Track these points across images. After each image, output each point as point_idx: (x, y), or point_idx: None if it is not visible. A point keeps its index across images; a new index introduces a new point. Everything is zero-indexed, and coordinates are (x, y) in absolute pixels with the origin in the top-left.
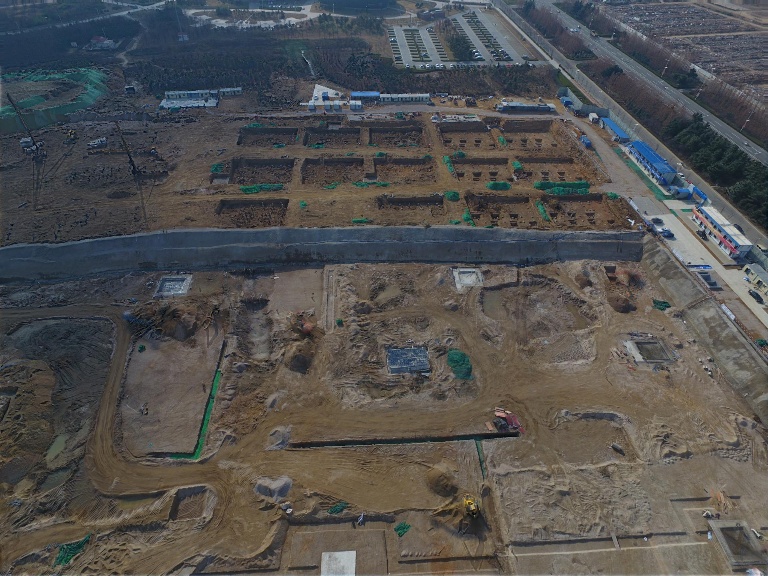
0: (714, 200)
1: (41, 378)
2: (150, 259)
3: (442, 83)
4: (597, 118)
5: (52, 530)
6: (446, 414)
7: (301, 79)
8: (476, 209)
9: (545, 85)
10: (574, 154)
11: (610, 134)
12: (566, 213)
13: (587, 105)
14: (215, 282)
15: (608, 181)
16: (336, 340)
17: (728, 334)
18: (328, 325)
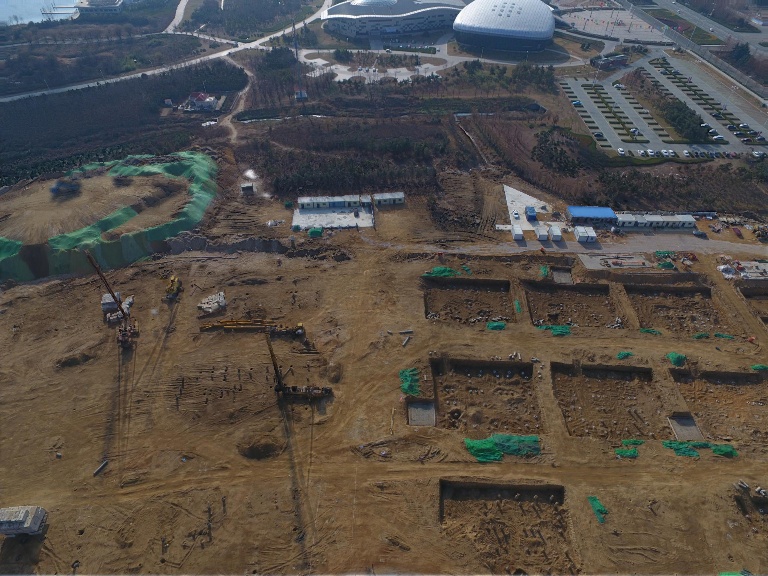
0: None
1: None
2: None
3: (689, 187)
4: None
5: None
6: None
7: (478, 173)
8: None
9: None
10: None
11: None
12: None
13: None
14: None
15: None
16: None
17: None
18: None
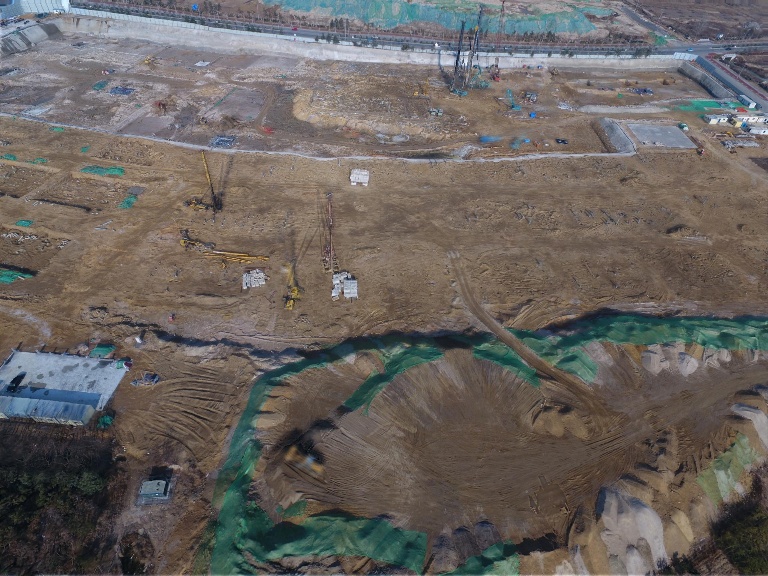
0: None
1: (297, 110)
2: None
3: None
4: None
5: None
6: None
7: None
8: None
9: None
10: None
11: None
12: None
13: None
14: (195, 138)
15: None
16: None
17: None
18: None
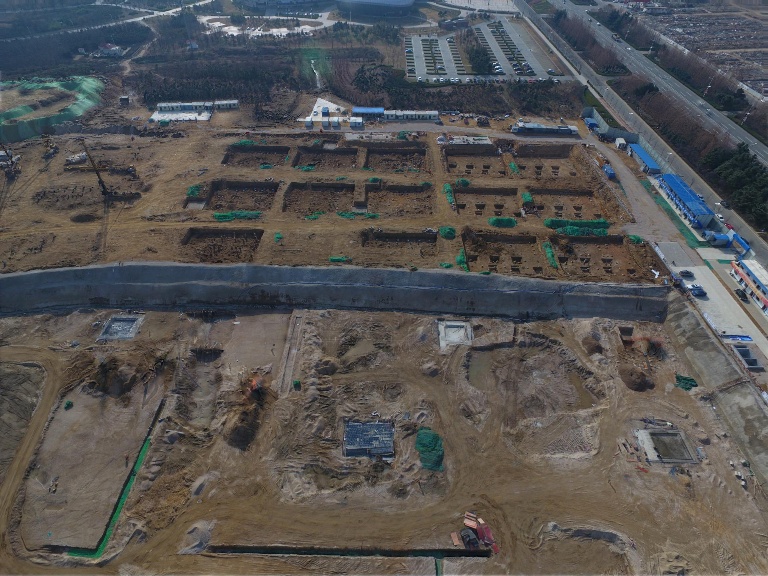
0: (759, 250)
1: None
2: (102, 294)
3: (455, 99)
4: (625, 144)
5: None
6: (404, 518)
7: (304, 92)
8: (473, 249)
9: (569, 104)
10: (594, 186)
11: (638, 163)
12: (578, 258)
13: (614, 129)
14: (168, 325)
15: (631, 221)
16: (289, 407)
17: None
18: (283, 387)
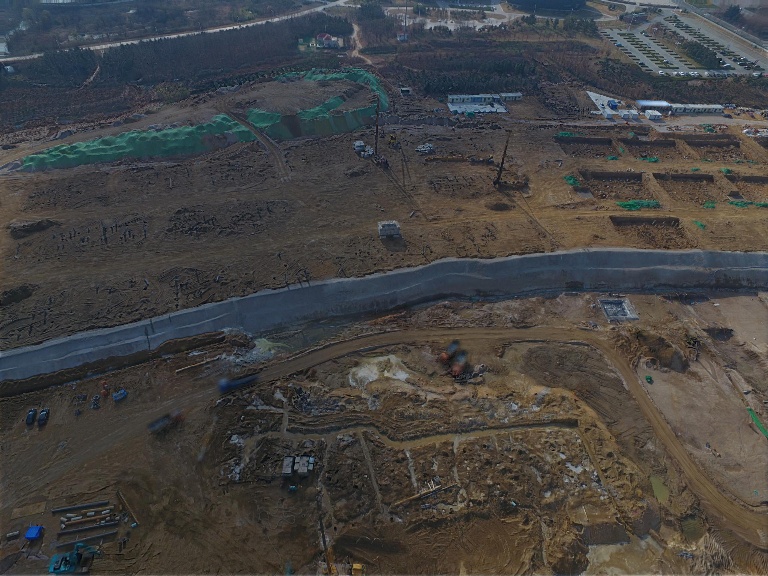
0: None
1: (588, 410)
2: (577, 279)
3: None
4: None
5: None
6: None
7: (564, 85)
8: None
9: None
10: None
11: None
12: None
13: None
14: (658, 307)
15: None
16: None
17: None
18: None
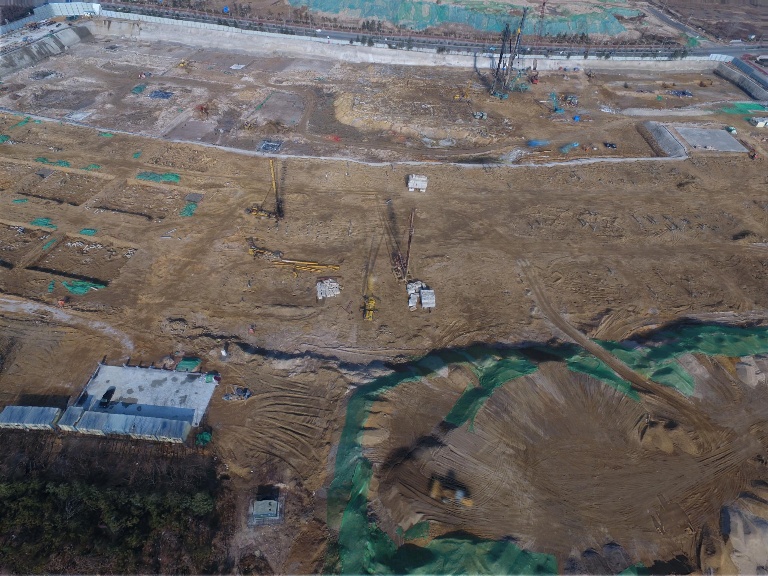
0: None
1: (340, 114)
2: None
3: None
4: None
5: (325, 83)
6: (165, 80)
7: None
8: None
9: None
10: None
11: None
12: None
13: None
14: (241, 143)
15: None
16: None
17: (4, 59)
18: None
